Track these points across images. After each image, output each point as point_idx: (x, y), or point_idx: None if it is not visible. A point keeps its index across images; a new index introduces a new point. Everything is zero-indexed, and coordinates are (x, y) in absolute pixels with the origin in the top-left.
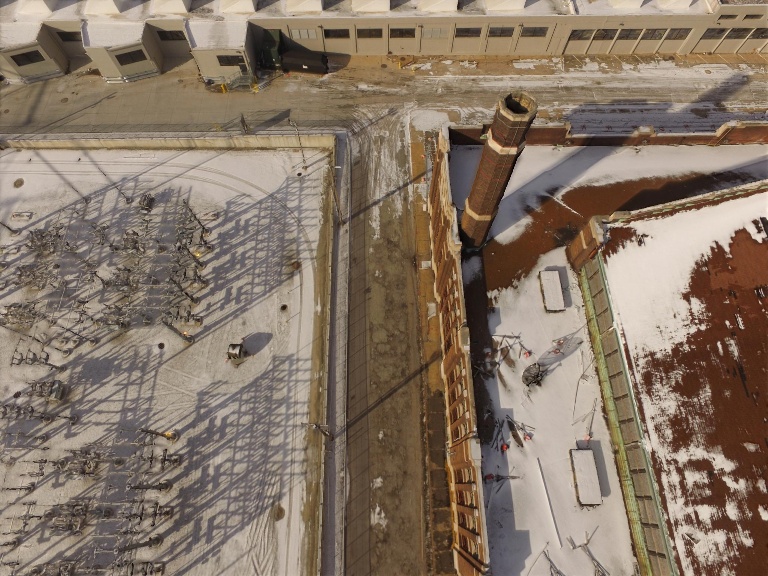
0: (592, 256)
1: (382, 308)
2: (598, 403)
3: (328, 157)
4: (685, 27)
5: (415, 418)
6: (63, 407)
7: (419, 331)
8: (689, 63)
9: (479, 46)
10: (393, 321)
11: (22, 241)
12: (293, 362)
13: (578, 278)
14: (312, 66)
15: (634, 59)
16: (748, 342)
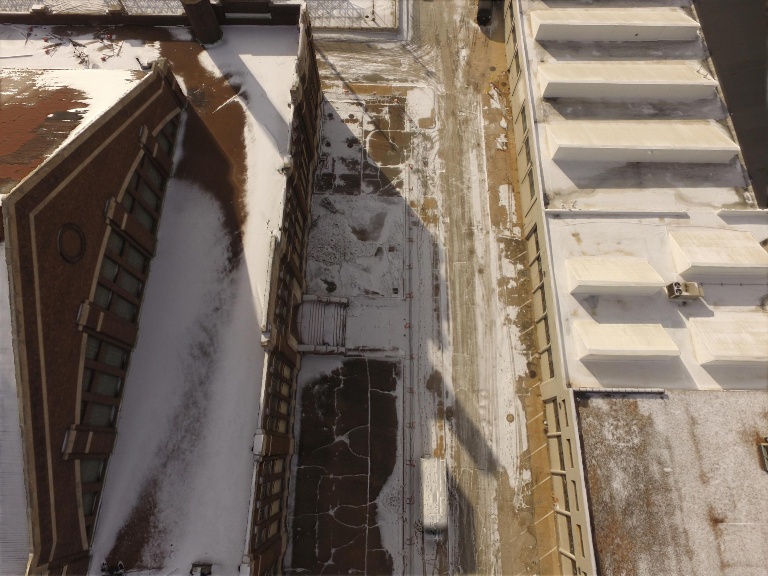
0: None
1: None
2: None
3: None
4: (554, 362)
5: None
6: None
7: None
8: (525, 396)
9: None
10: None
11: None
12: None
13: None
14: (478, 6)
15: (526, 323)
16: (4, 96)
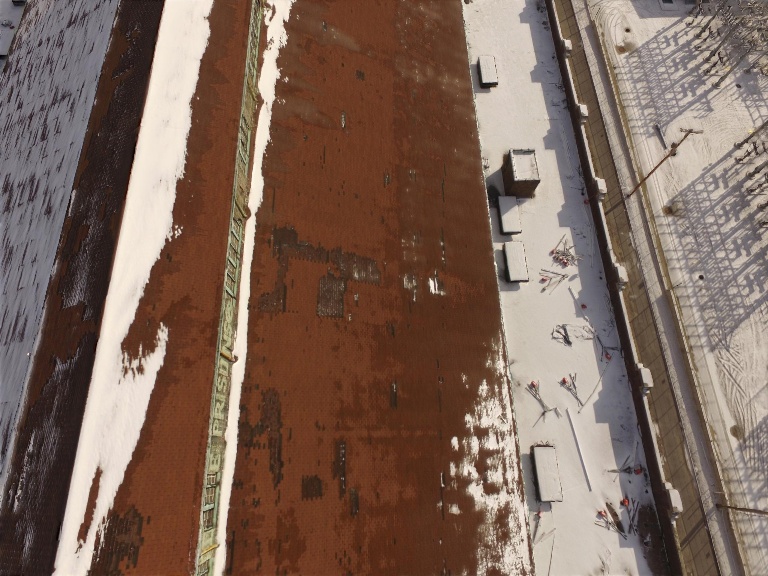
0: None
1: None
2: None
3: None
4: None
5: None
6: None
7: None
8: None
9: None
10: None
11: None
12: None
13: None
14: None
15: None
16: None
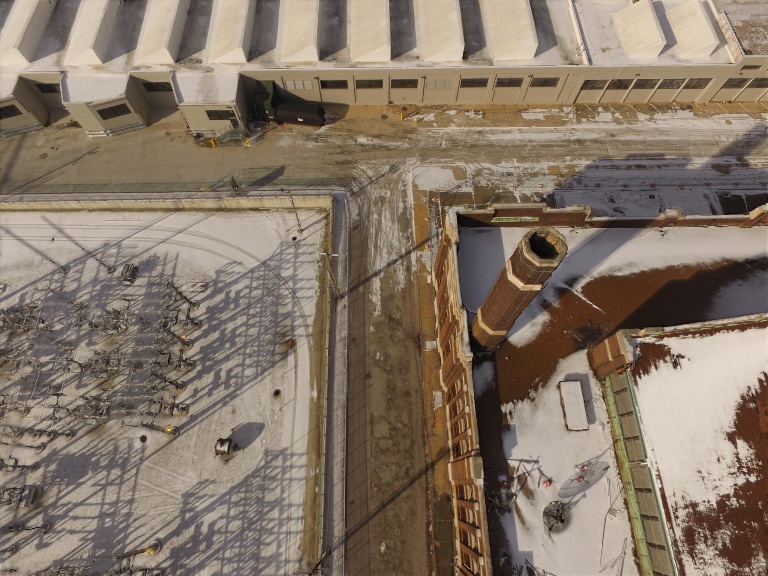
0: (619, 372)
1: (384, 397)
2: (628, 544)
3: (325, 219)
4: (705, 77)
5: (420, 527)
6: (35, 512)
7: (424, 423)
8: (708, 113)
9: (485, 96)
10: (396, 412)
11: None
12: (287, 457)
13: (602, 388)
14: (308, 119)
15: (650, 108)
16: None
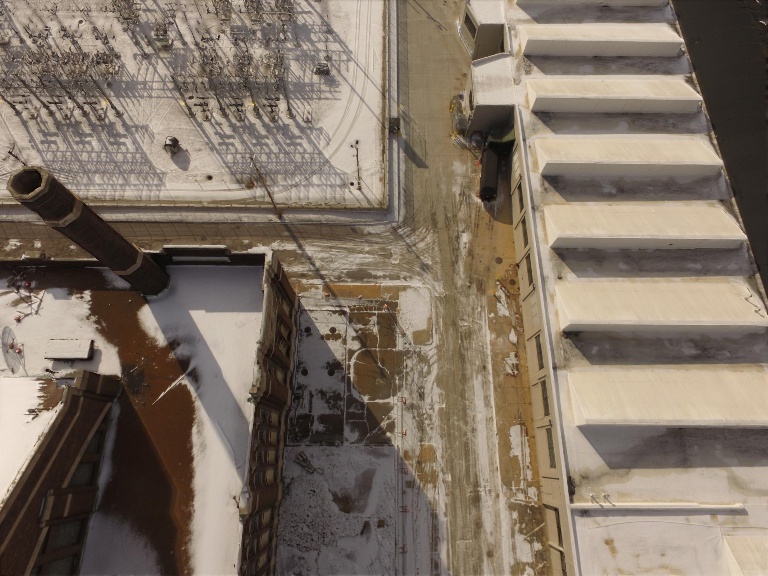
0: None
1: None
2: None
3: None
4: None
5: None
6: (156, 49)
7: None
8: None
9: None
10: None
11: (294, 1)
12: (159, 187)
13: None
14: (481, 181)
15: None
16: None
